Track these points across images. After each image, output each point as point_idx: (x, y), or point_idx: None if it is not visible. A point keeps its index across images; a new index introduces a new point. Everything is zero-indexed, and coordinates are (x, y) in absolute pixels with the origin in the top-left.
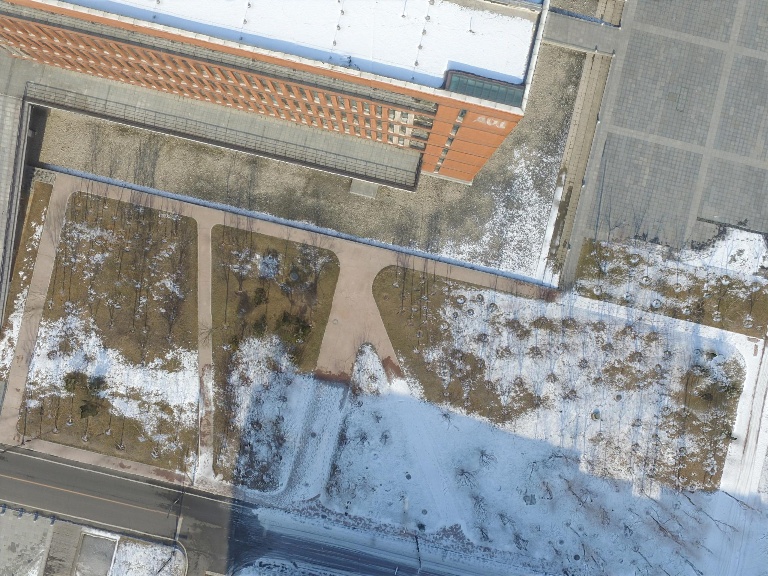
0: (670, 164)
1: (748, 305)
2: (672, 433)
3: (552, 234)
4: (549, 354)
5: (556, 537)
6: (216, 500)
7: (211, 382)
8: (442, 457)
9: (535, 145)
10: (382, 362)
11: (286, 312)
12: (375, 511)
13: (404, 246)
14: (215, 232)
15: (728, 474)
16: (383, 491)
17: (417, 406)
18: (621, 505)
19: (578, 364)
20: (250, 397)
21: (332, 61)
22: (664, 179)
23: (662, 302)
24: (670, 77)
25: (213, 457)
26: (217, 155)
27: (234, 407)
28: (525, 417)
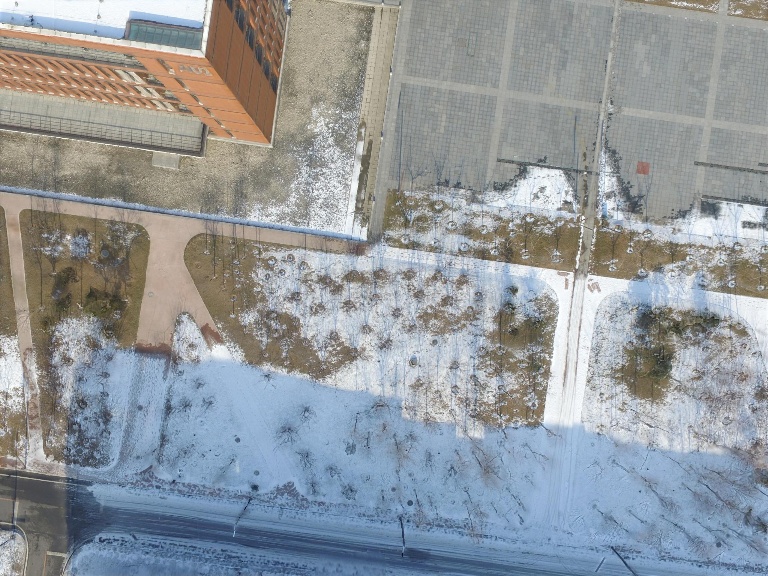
0: (466, 109)
1: (554, 240)
2: (490, 372)
3: (357, 188)
4: (363, 306)
5: (387, 485)
6: (50, 481)
7: (34, 365)
8: (269, 417)
9: (332, 102)
10: (201, 330)
11: (92, 288)
12: (208, 477)
13: (212, 214)
14: (23, 217)
15: (550, 407)
16: (213, 456)
17: (239, 370)
18: (447, 447)
19: (392, 313)
20: (73, 376)
21: (15, 22)
22: (461, 124)
23: (470, 245)
24: (458, 23)
25: (43, 439)
26: (19, 141)
27: (59, 388)
28: (344, 370)
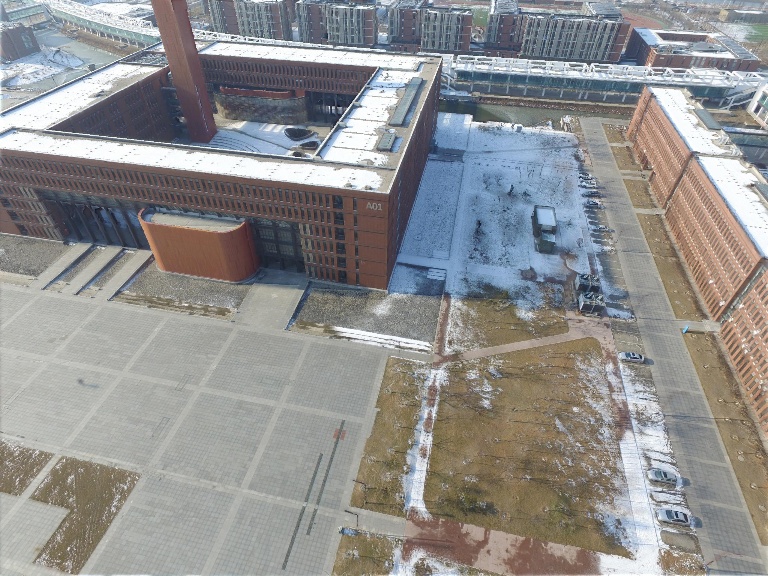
0: None
1: None
2: None
3: None
4: None
5: None
6: None
7: None
8: None
9: None
10: None
11: None
12: None
13: None
14: None
15: None
16: None
17: None
18: None
19: None
20: None
21: None
22: None
23: None
24: None
25: None
26: None
27: None
28: None
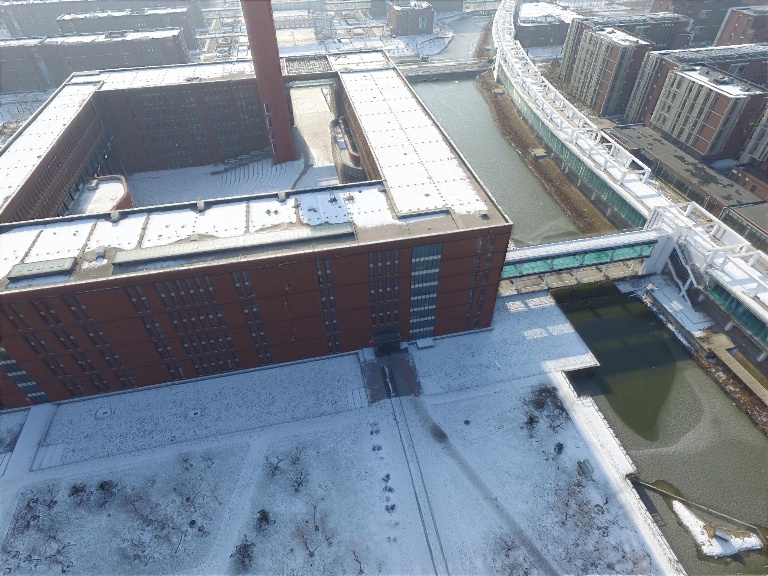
0: None
1: None
2: None
3: None
4: None
5: None
6: None
7: None
8: None
9: None
10: None
11: None
12: None
13: None
14: None
15: None
16: None
17: None
18: None
19: None
20: None
21: None
22: None
23: None
24: None
25: None
26: None
27: None
28: None
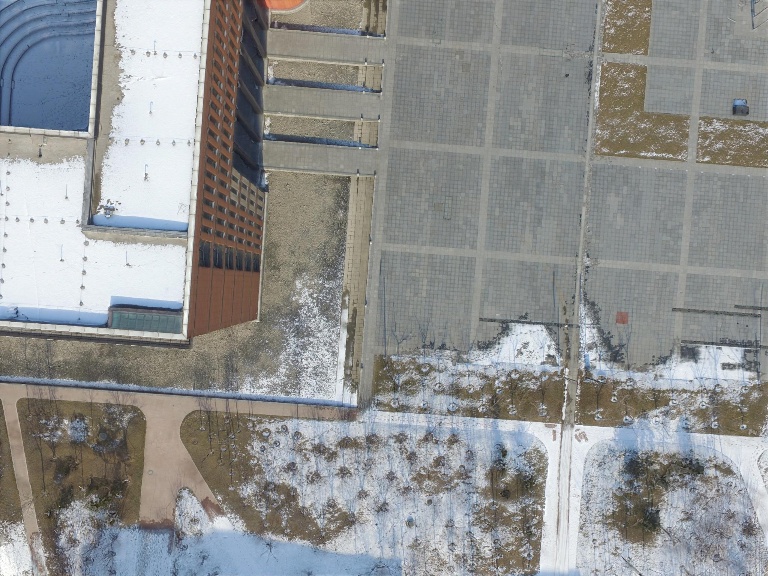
0: (446, 272)
1: (540, 394)
2: (485, 528)
3: (345, 355)
4: (357, 471)
5: None
6: None
7: (41, 548)
8: None
9: (315, 273)
10: (201, 503)
11: (93, 478)
12: None
13: (205, 389)
14: (20, 406)
15: (546, 556)
16: None
17: (241, 539)
18: None
19: (386, 477)
20: (80, 557)
21: (0, 314)
22: (442, 287)
23: (458, 404)
24: (433, 188)
25: None
26: None
27: (67, 568)
28: (343, 535)
